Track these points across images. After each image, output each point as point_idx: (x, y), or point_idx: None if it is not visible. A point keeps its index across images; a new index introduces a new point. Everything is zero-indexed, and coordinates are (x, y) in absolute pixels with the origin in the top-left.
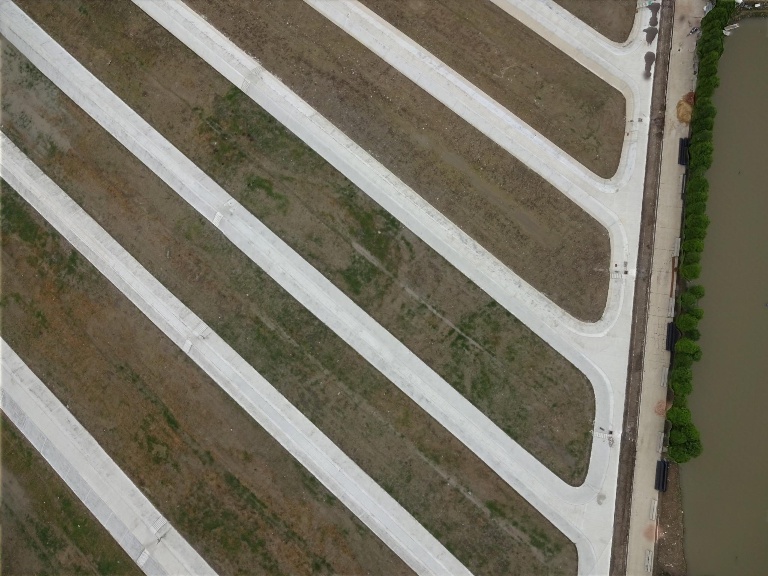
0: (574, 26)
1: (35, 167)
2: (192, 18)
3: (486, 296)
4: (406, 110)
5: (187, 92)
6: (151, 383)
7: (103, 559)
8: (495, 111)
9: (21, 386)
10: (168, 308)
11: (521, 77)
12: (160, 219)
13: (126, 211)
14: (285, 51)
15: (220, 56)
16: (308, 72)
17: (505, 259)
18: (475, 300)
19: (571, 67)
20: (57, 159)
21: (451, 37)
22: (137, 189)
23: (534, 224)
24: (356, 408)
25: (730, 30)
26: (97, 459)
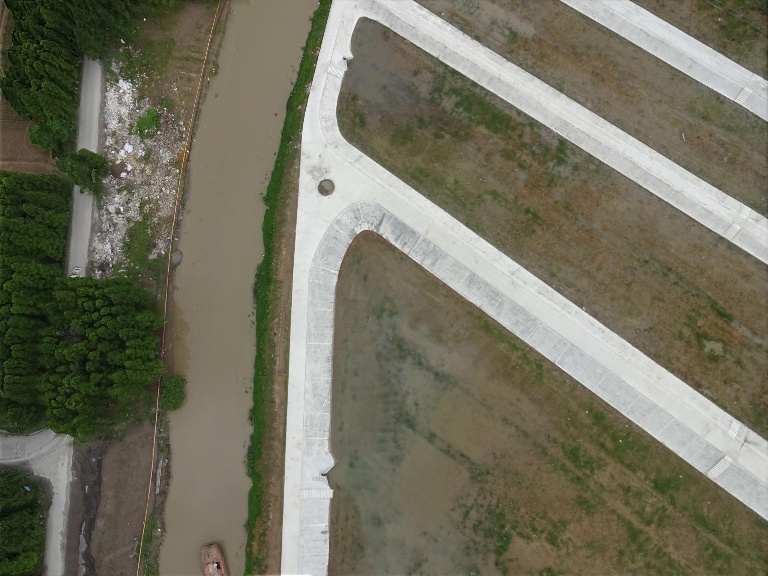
0: None
1: (495, 54)
2: None
3: None
4: None
5: None
6: (688, 275)
7: (660, 475)
8: None
9: (526, 289)
10: (702, 191)
11: None
12: (665, 101)
13: (620, 95)
14: None
15: None
16: None
17: None
18: None
19: None
20: (521, 45)
21: None
22: (630, 71)
23: None
24: None
25: None
26: (640, 362)
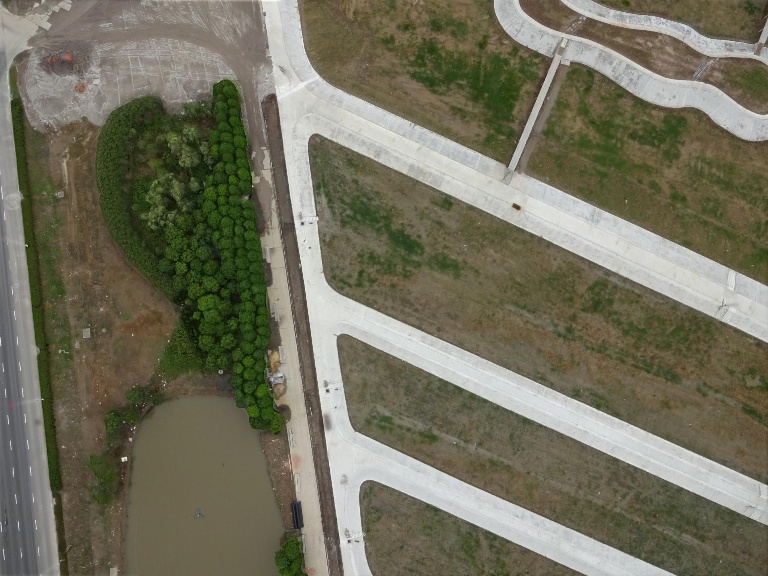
0: None
1: None
2: None
3: None
4: None
5: None
6: None
7: None
8: None
9: None
10: None
11: None
12: None
13: None
14: None
15: None
16: None
17: None
18: None
19: None
20: None
21: None
22: None
23: None
24: (579, 485)
25: None
26: None
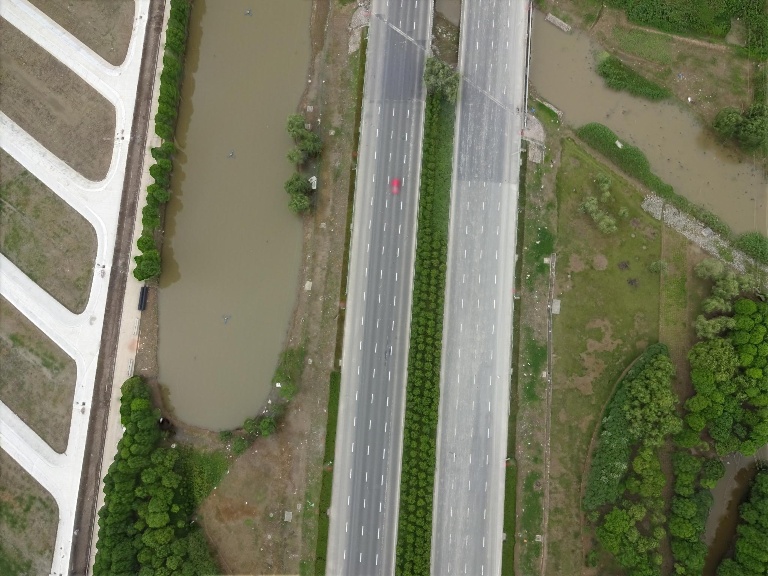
0: None
1: None
2: None
3: (20, 167)
4: None
5: None
6: None
7: None
8: (33, 16)
9: None
10: None
11: None
12: None
13: None
14: None
15: None
16: None
17: (37, 135)
18: (12, 171)
19: None
20: None
21: None
22: None
23: (61, 106)
24: None
25: None
26: None
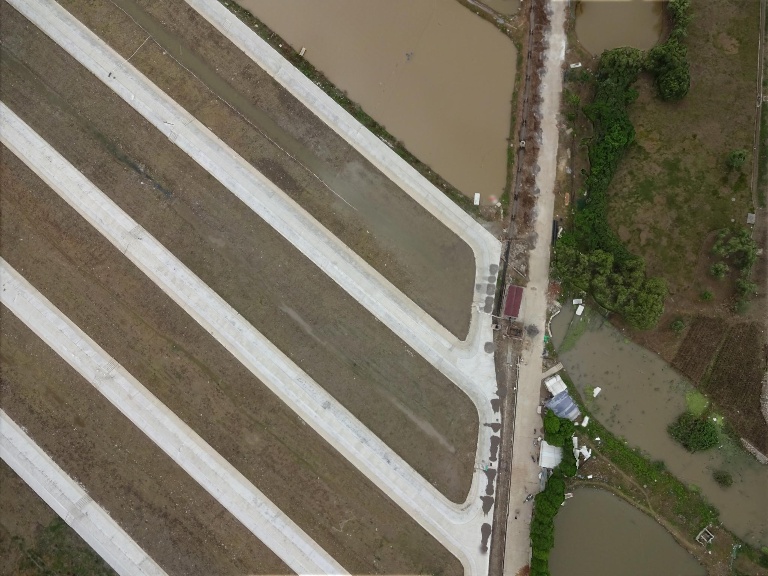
0: (412, 486)
1: None
2: (10, 432)
3: None
4: (242, 561)
5: (6, 517)
6: None
7: None
8: (333, 575)
9: None
10: None
11: (360, 533)
12: None
13: None
14: (113, 479)
15: (41, 483)
16: (138, 506)
17: None
18: None
19: (410, 526)
20: None
21: (289, 480)
22: None
23: None
24: None
25: (564, 500)
26: None
